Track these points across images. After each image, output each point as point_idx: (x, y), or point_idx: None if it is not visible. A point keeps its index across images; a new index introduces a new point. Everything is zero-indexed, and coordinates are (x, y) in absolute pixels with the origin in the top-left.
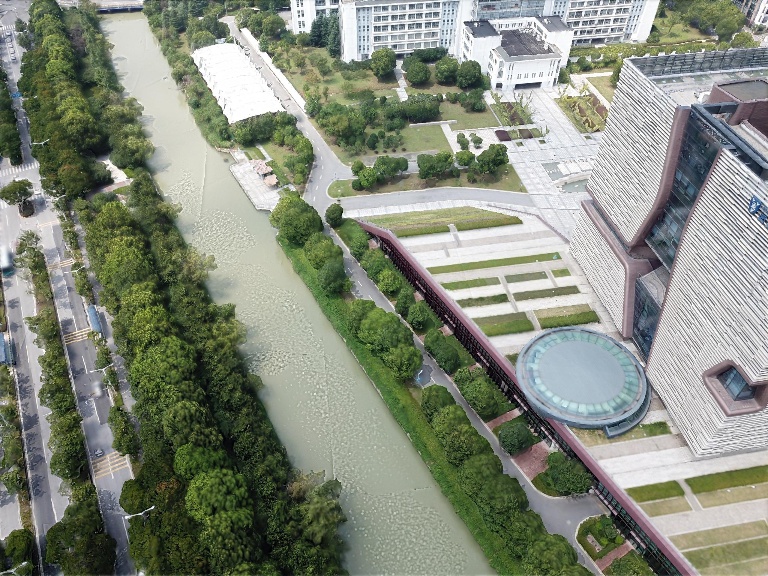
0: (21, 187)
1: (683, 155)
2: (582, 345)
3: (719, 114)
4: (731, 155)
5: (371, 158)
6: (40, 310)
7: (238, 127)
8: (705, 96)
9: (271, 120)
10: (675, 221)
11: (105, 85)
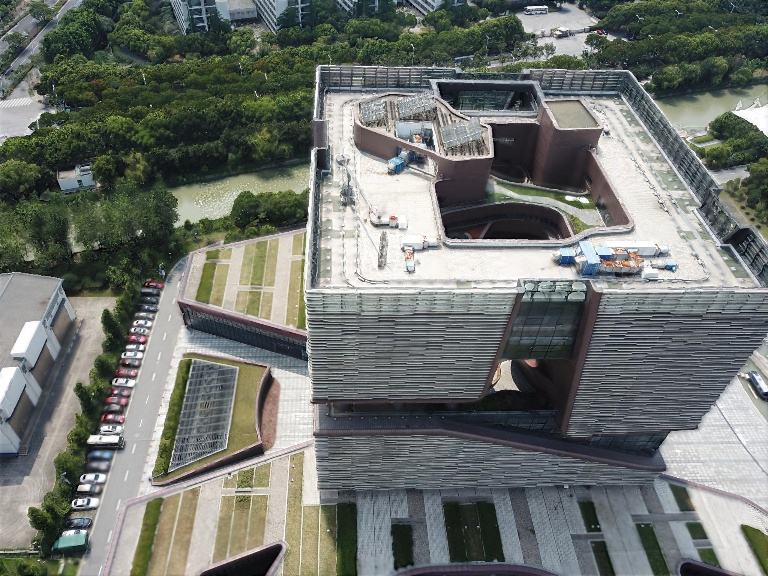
0: (604, 43)
1: None
2: None
3: None
4: None
5: (730, 204)
6: (496, 67)
7: (724, 115)
8: None
9: (748, 131)
10: None
11: (766, 59)
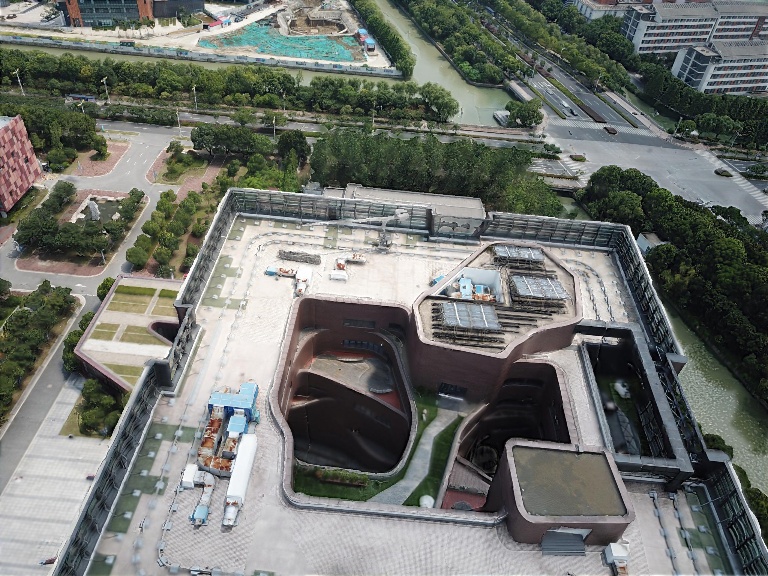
0: None
1: None
2: None
3: None
4: None
5: None
6: None
7: None
8: None
9: None
10: None
11: None
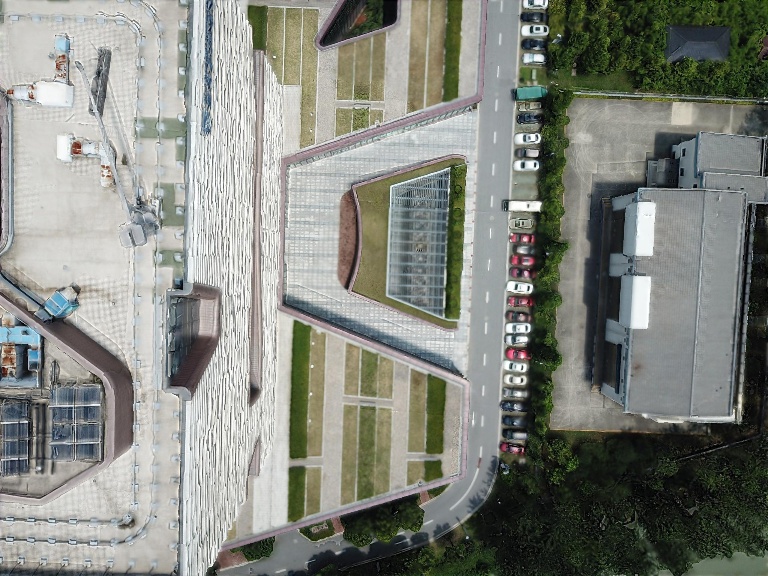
0: None
1: None
2: None
3: None
4: None
5: None
6: None
7: None
8: None
9: None
10: None
11: None
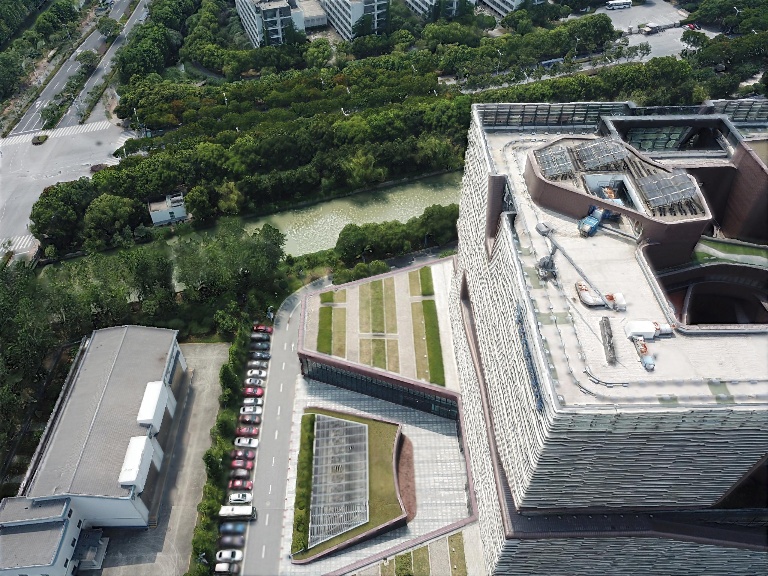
0: (702, 40)
1: (677, 147)
2: None
3: (726, 139)
4: None
5: None
6: (587, 70)
7: None
8: None
9: None
10: None
11: None
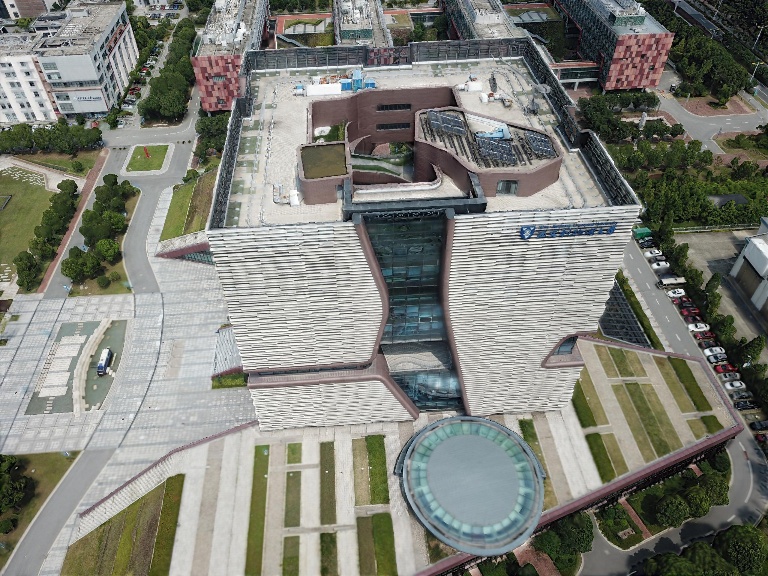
0: None
1: (378, 254)
2: (435, 465)
3: None
4: (468, 216)
5: None
6: None
7: None
8: (299, 196)
9: None
10: (412, 305)
11: None
